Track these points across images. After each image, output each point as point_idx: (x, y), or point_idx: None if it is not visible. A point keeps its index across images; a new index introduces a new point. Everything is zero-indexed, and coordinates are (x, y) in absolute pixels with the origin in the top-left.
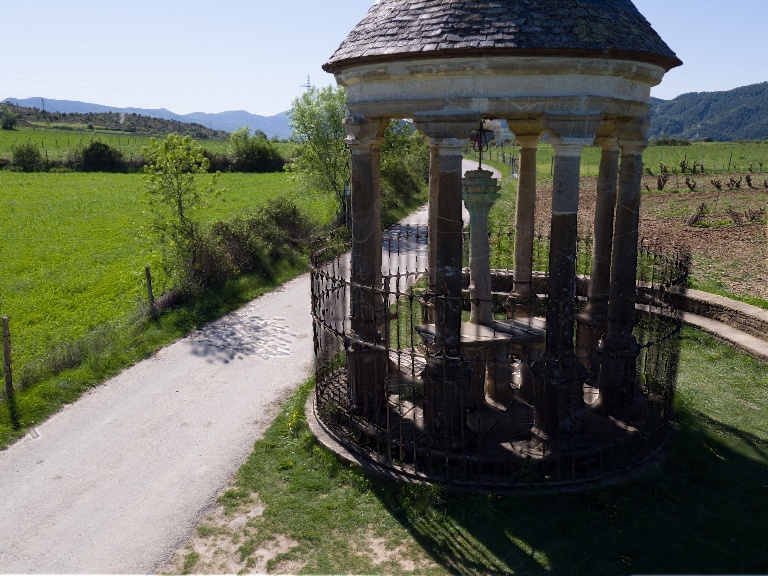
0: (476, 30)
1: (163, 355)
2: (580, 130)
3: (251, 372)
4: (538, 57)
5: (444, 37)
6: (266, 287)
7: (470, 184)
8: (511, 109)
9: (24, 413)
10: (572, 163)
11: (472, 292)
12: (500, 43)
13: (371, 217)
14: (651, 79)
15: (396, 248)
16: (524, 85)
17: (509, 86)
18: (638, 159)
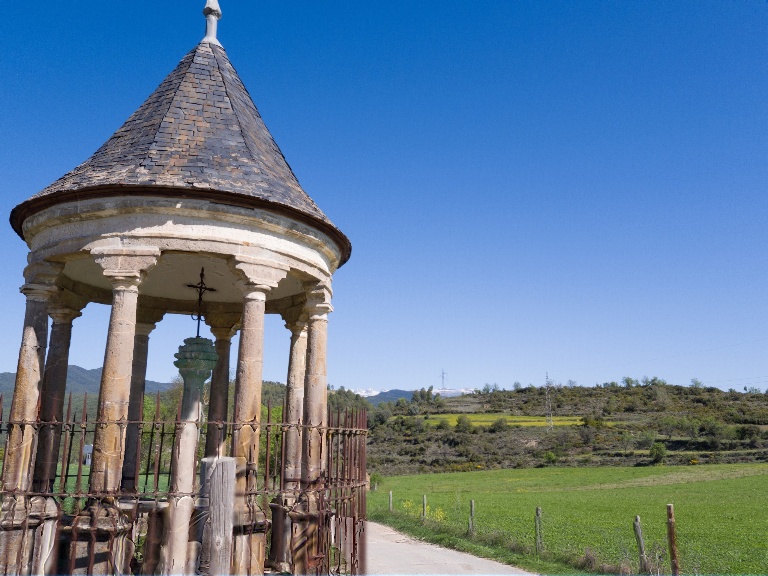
0: None
1: None
2: None
3: None
4: None
5: None
6: None
7: None
8: None
9: None
10: None
11: None
12: None
13: None
14: None
15: None
16: None
17: None
18: None
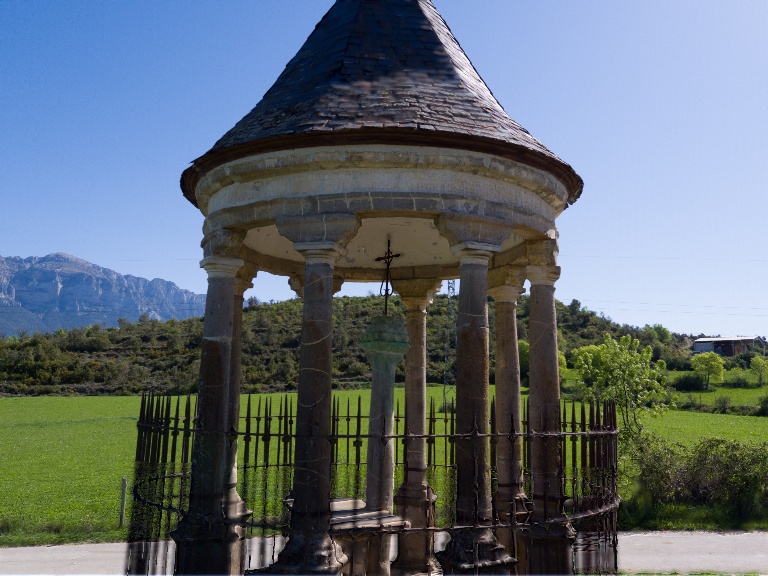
0: None
1: None
2: None
3: None
4: None
5: None
6: (714, 525)
7: None
8: None
9: None
10: None
11: None
12: None
13: None
14: (284, 168)
15: None
16: None
17: None
18: (306, 269)
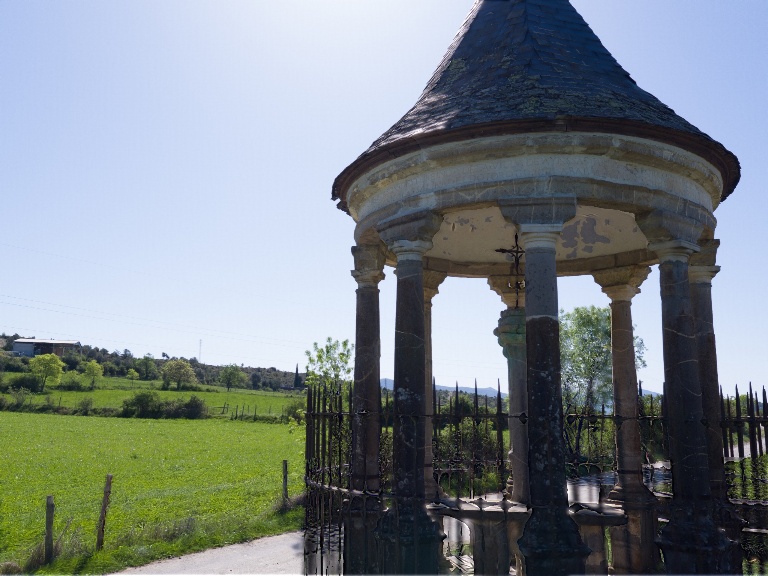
0: (417, 126)
1: (257, 542)
2: (545, 216)
3: (317, 564)
4: (477, 139)
5: (388, 138)
6: None
7: (501, 324)
8: (459, 200)
9: (87, 566)
10: (539, 256)
11: (510, 458)
12: (431, 129)
13: (372, 354)
14: (669, 164)
15: None
16: (472, 173)
17: (456, 177)
18: (678, 266)
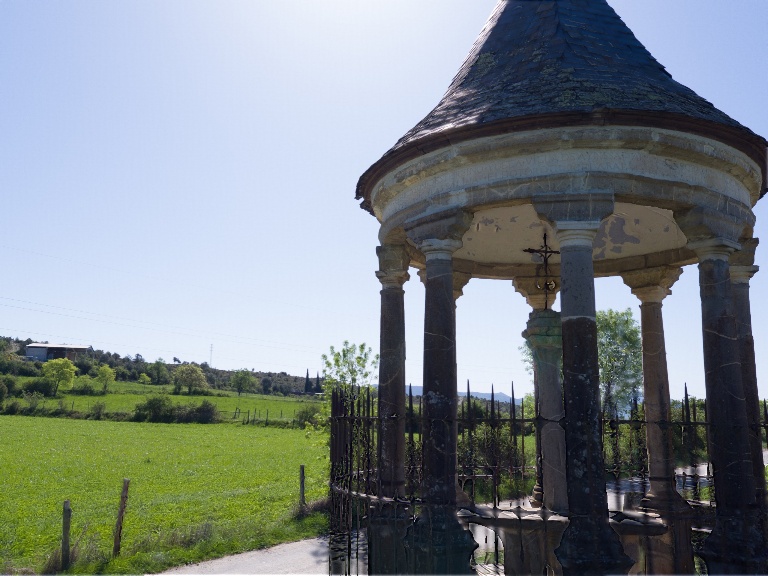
0: (447, 121)
1: (275, 549)
2: (582, 213)
3: (338, 572)
4: (510, 133)
5: (416, 134)
6: None
7: (530, 326)
8: (491, 197)
9: (104, 572)
10: (576, 254)
11: None
12: (462, 124)
13: (397, 356)
14: (709, 159)
15: (624, 491)
16: (505, 169)
17: (488, 173)
18: (719, 265)
